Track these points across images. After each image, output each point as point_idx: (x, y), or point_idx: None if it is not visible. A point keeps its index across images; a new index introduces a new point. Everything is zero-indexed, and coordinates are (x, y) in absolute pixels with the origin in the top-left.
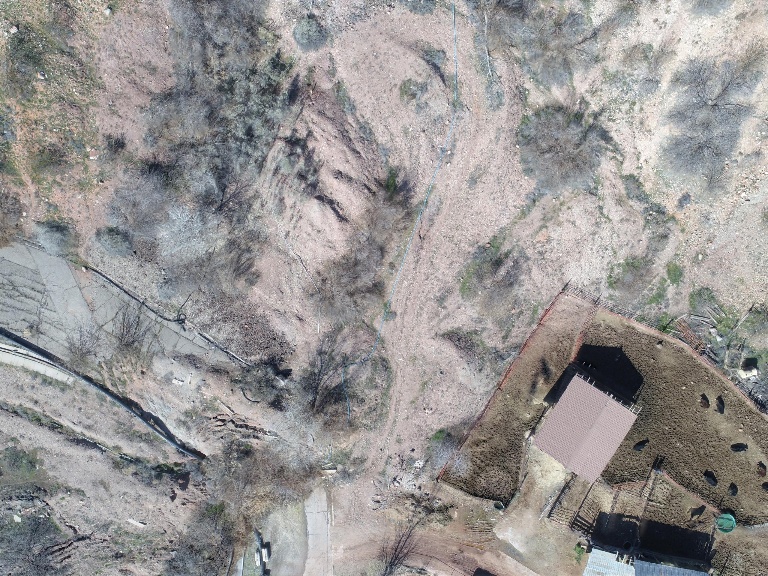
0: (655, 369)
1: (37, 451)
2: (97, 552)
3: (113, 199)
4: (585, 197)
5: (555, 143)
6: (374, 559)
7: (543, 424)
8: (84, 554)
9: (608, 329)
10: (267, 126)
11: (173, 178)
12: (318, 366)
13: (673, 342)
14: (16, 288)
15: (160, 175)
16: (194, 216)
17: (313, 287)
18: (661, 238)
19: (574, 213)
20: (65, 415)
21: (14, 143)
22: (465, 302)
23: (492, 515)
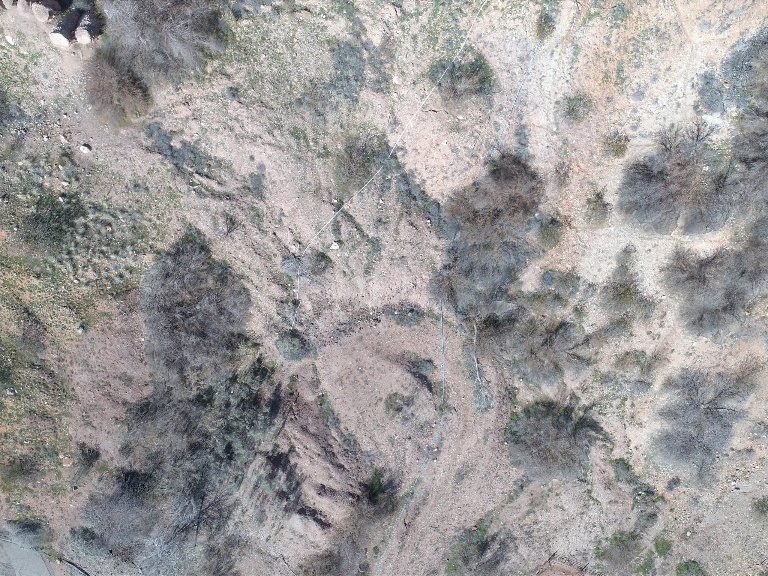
0: None
1: None
2: None
3: (88, 504)
4: (574, 485)
5: (544, 448)
6: None
7: None
8: None
9: None
10: (247, 446)
11: (150, 488)
12: None
13: None
14: None
15: (136, 486)
16: (171, 551)
17: None
18: (650, 516)
19: (562, 499)
20: None
21: None
22: None
23: None
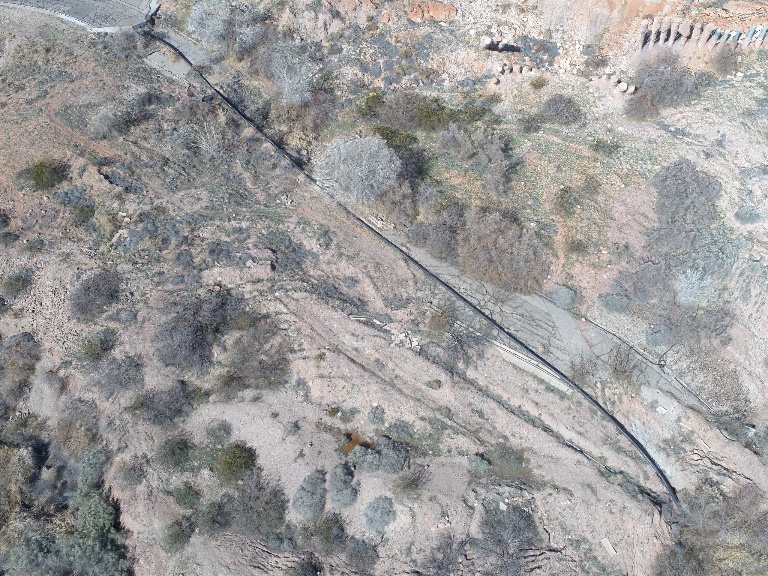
0: None
1: (524, 451)
2: (564, 573)
3: (617, 276)
4: None
5: None
6: None
7: None
8: (553, 570)
9: None
10: None
11: None
12: None
13: None
14: (534, 320)
15: None
16: (704, 275)
17: None
18: None
19: None
20: (560, 420)
21: (555, 235)
22: None
23: None
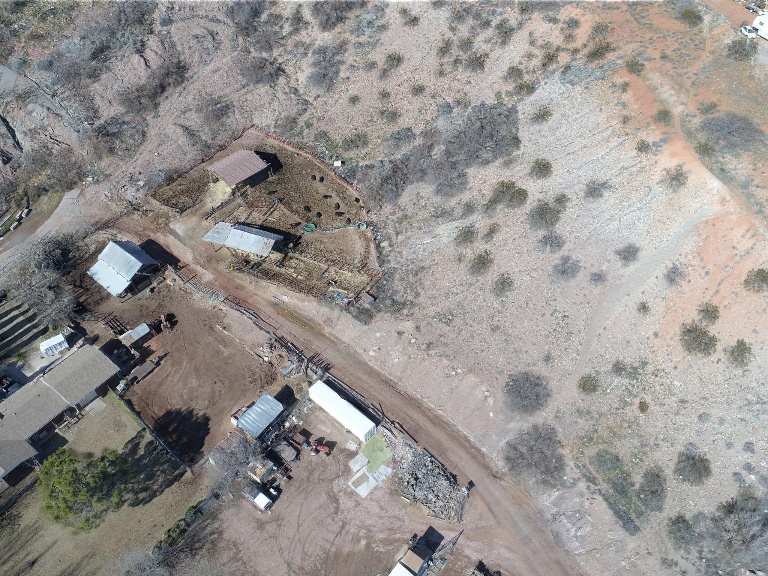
0: (291, 164)
1: None
2: None
3: (54, 52)
4: (267, 87)
5: (254, 60)
6: (88, 225)
7: None
8: None
9: (271, 147)
10: None
11: None
12: (108, 123)
13: (304, 155)
14: None
15: None
16: (81, 40)
17: (123, 92)
18: None
19: (261, 91)
20: None
21: None
22: (195, 114)
23: (172, 217)
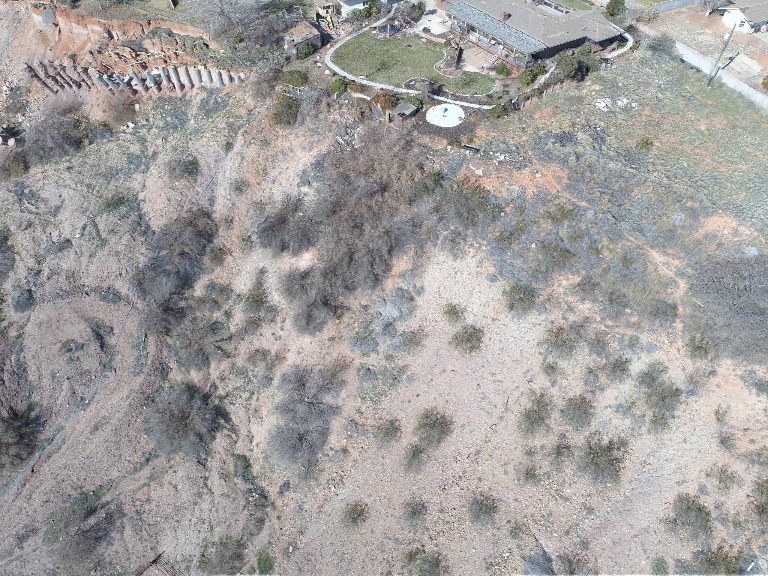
0: None
1: None
2: None
3: None
4: (191, 464)
5: (169, 407)
6: None
7: None
8: None
9: None
10: None
11: None
12: None
13: None
14: None
15: None
16: None
17: None
18: (257, 521)
19: (178, 477)
20: None
21: None
22: (43, 546)
23: None
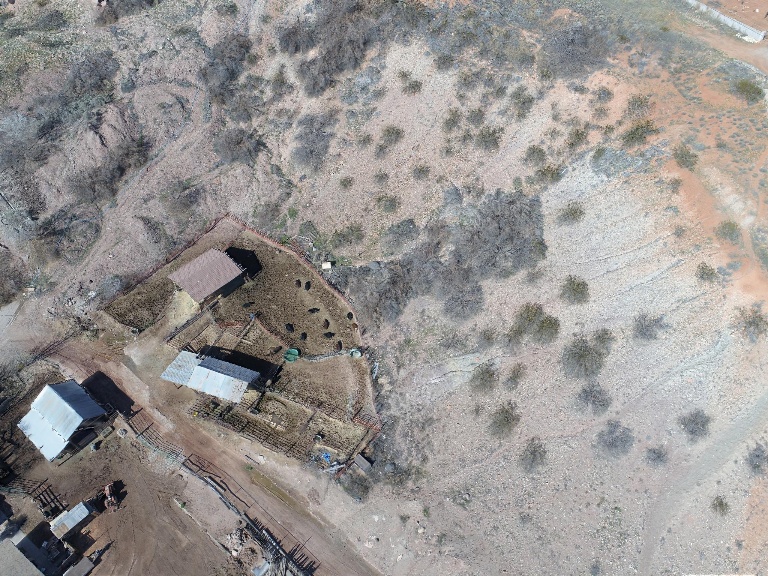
0: (271, 264)
1: None
2: None
3: None
4: (245, 166)
5: (229, 134)
6: (26, 352)
7: (179, 268)
8: None
9: (249, 241)
10: None
11: None
12: (55, 217)
13: (287, 252)
14: None
15: None
16: (25, 117)
17: (74, 177)
18: None
19: (237, 172)
20: None
21: None
22: (160, 203)
23: (128, 339)
